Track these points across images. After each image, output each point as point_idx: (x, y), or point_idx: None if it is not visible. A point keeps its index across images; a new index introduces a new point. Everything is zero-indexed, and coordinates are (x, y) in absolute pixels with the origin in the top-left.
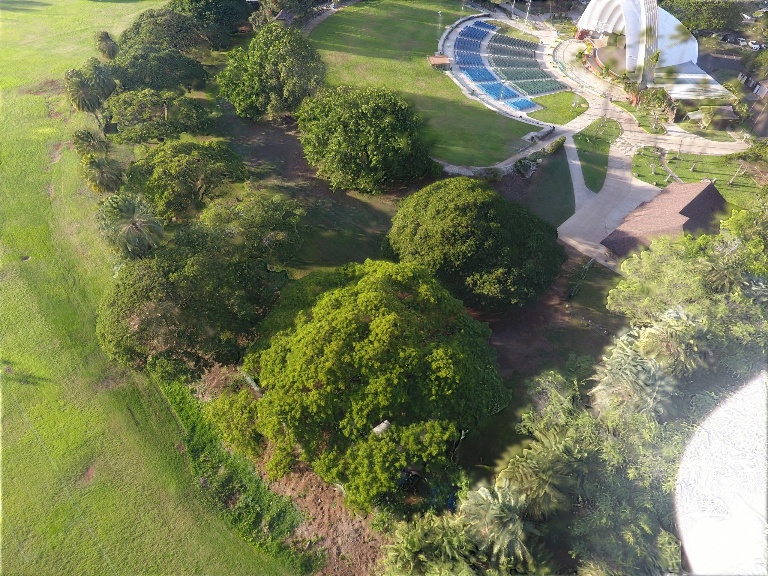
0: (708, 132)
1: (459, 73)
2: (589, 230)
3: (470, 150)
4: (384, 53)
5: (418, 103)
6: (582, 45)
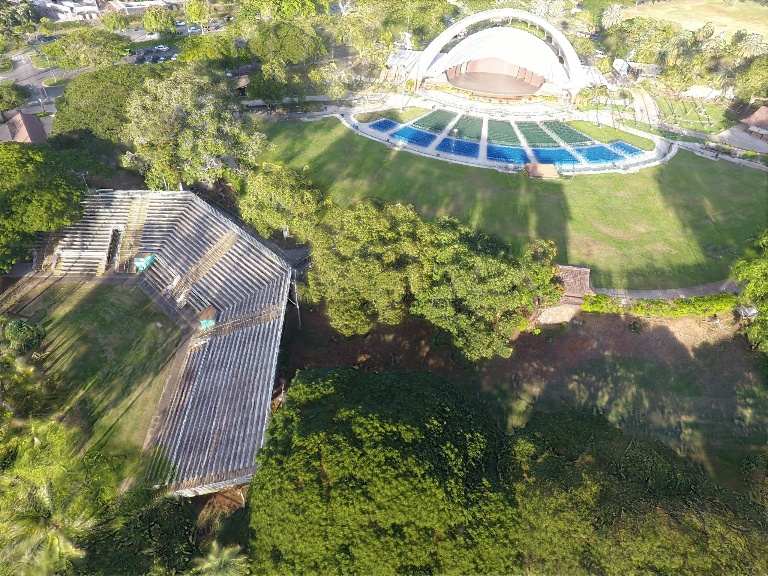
0: (619, 94)
1: (559, 168)
2: None
3: None
4: (539, 207)
5: (691, 202)
6: (434, 92)
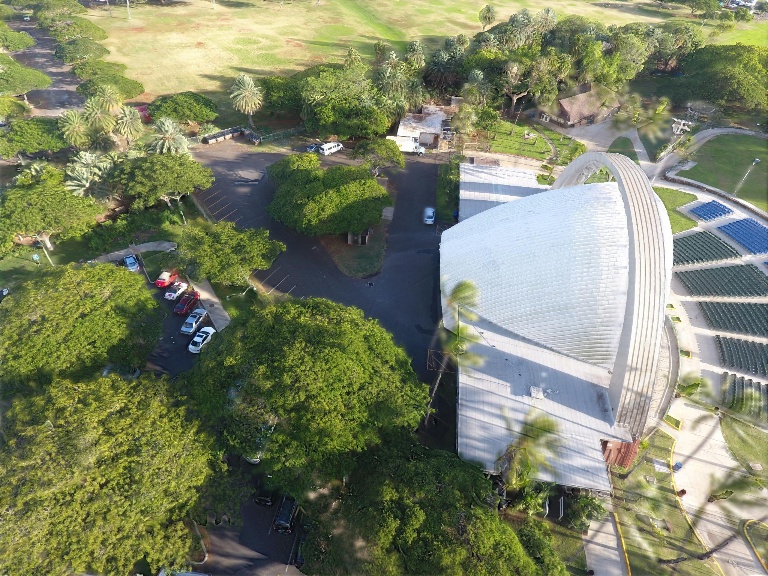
0: None
1: None
2: (628, 121)
3: (743, 148)
4: None
5: None
6: None
